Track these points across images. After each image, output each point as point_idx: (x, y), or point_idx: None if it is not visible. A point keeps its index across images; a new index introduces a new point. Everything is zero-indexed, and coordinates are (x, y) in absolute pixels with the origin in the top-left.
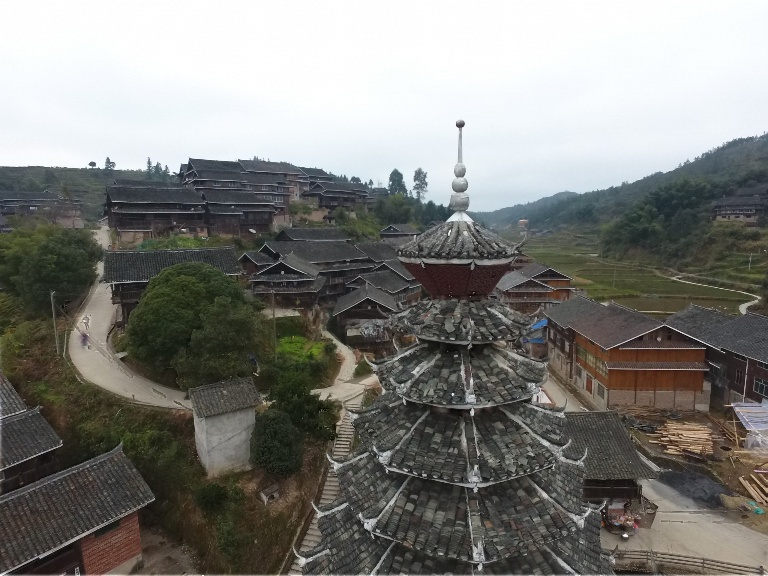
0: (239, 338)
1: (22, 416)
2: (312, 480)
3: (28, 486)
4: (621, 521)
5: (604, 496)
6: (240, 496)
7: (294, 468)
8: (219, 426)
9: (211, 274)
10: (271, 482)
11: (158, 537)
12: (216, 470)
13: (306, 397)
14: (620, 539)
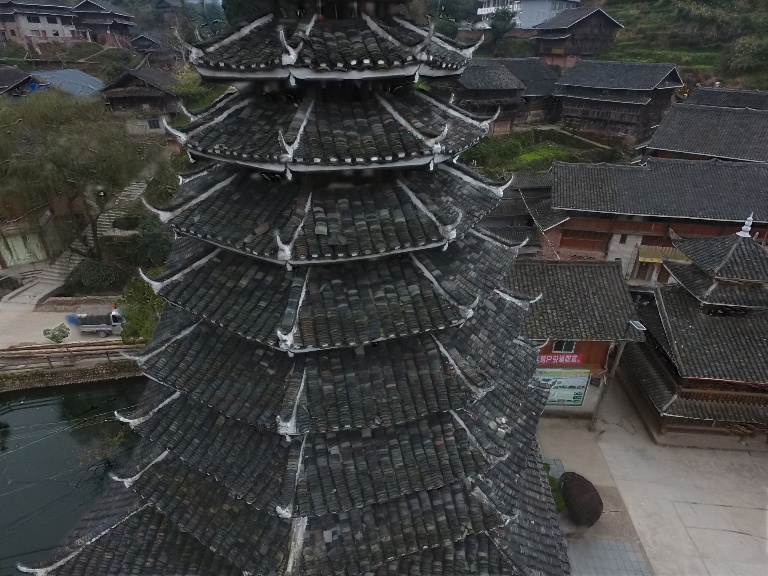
0: None
1: None
2: None
3: None
4: None
5: None
6: None
7: None
8: None
9: None
10: None
11: None
12: None
13: None
14: None
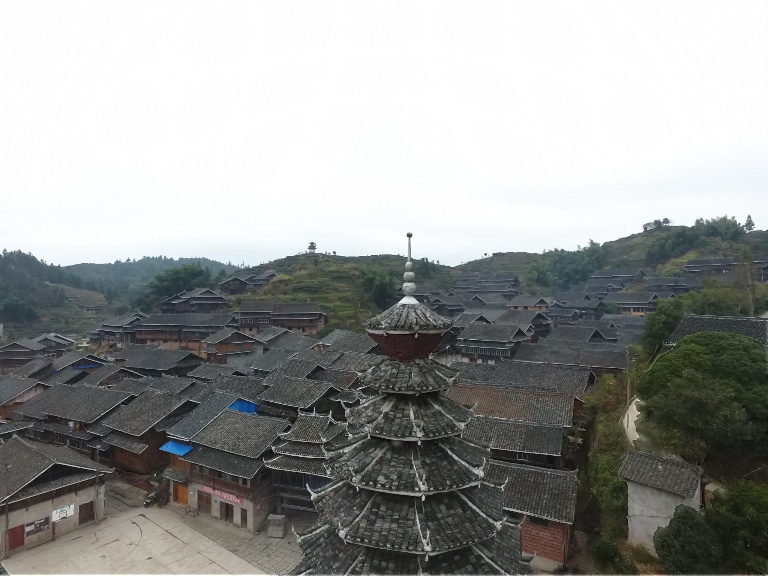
0: (691, 418)
1: (552, 426)
2: None
3: (513, 463)
4: None
5: None
6: (628, 572)
7: None
8: (642, 497)
9: (730, 347)
10: None
11: (594, 570)
12: (636, 540)
13: (748, 520)
14: None
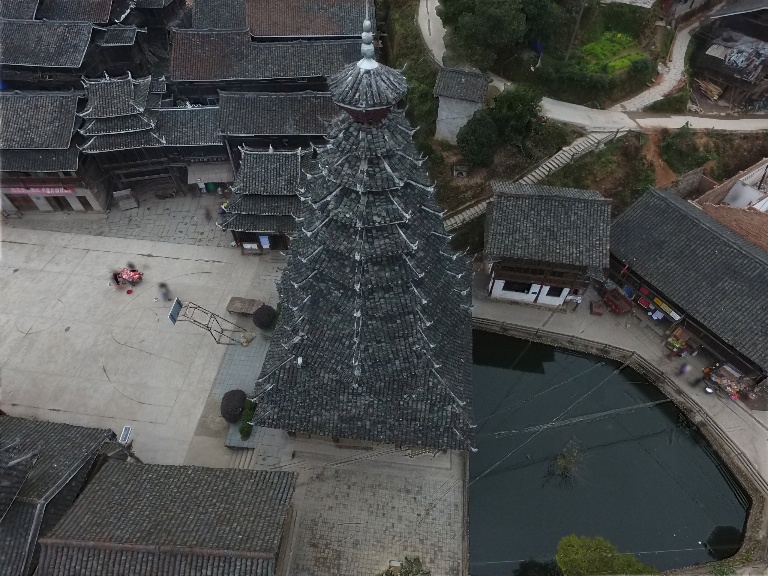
0: (491, 35)
1: None
2: (503, 179)
3: None
4: (720, 381)
5: (722, 354)
6: (439, 161)
7: (480, 163)
8: (449, 106)
9: None
10: (469, 164)
11: None
12: (441, 136)
13: (516, 114)
14: (703, 388)
